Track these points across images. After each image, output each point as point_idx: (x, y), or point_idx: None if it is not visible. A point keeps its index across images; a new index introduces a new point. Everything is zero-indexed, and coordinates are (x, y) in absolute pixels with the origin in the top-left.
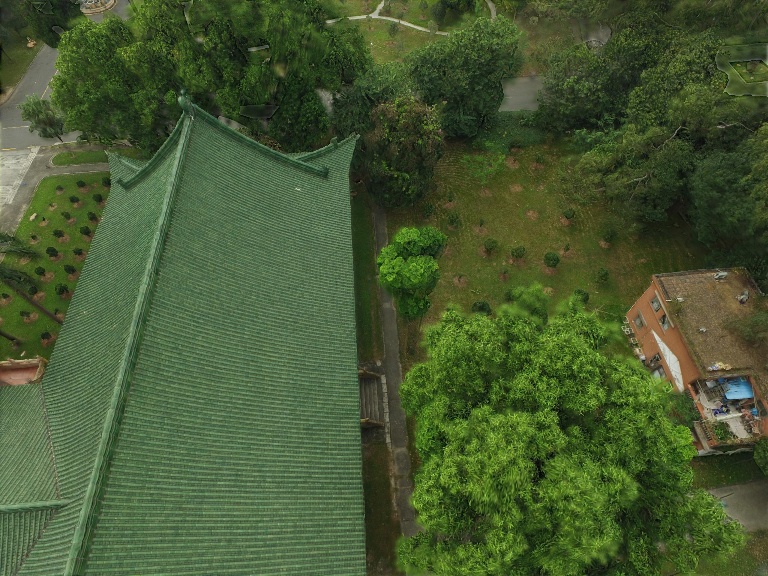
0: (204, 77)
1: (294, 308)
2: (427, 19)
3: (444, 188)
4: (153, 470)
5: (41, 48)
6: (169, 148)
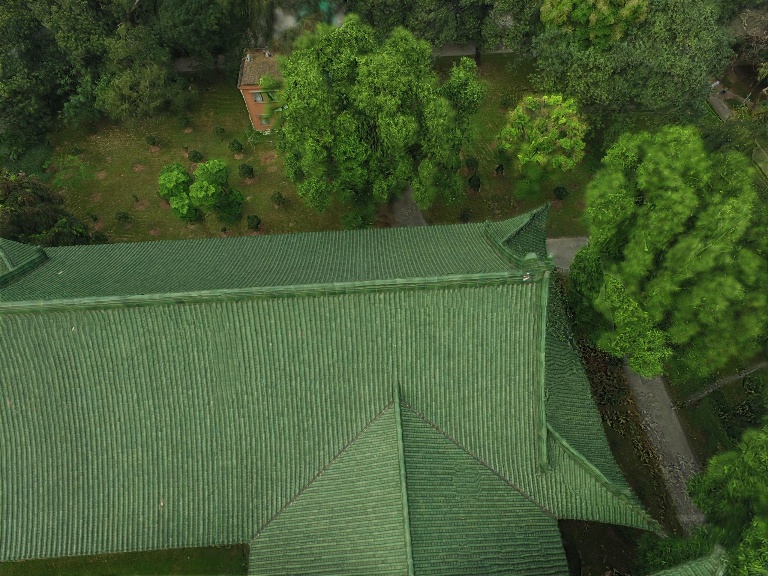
0: None
1: None
2: None
3: None
4: None
5: None
6: None
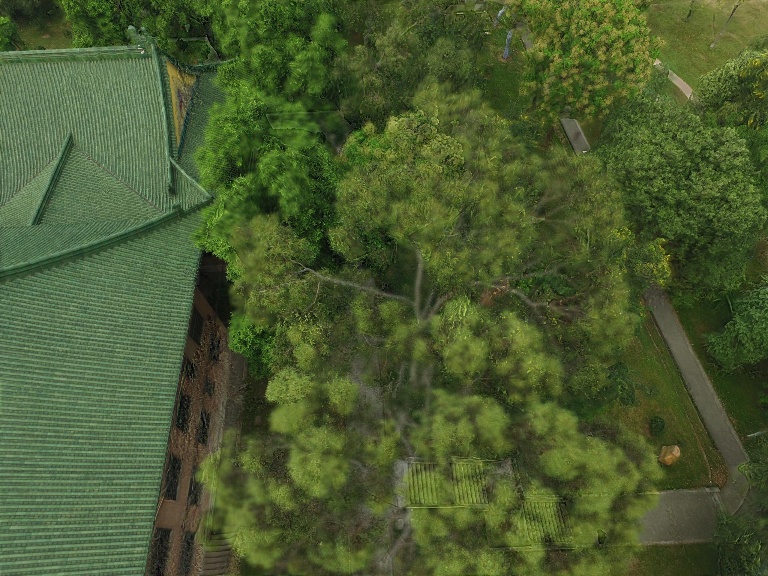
0: None
1: None
2: None
3: None
4: None
5: None
6: None
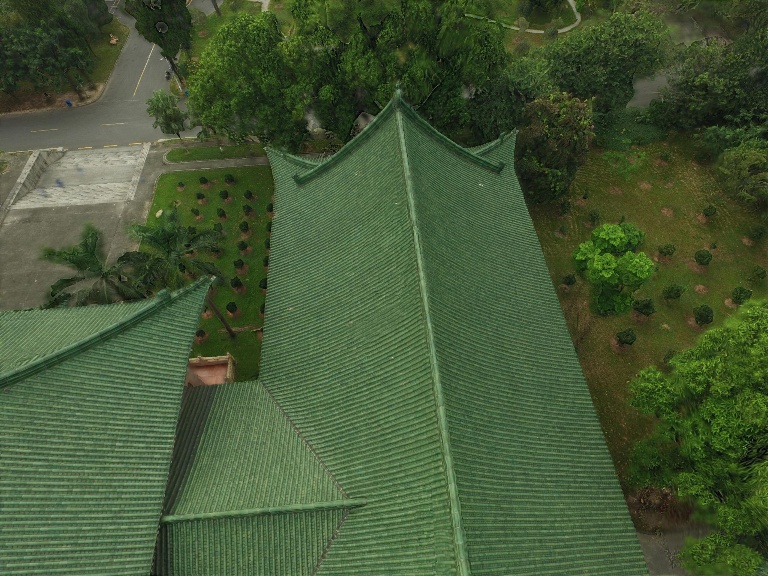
0: (371, 71)
1: (514, 305)
2: (510, 16)
3: (572, 185)
4: (473, 469)
5: (124, 45)
6: (358, 143)
